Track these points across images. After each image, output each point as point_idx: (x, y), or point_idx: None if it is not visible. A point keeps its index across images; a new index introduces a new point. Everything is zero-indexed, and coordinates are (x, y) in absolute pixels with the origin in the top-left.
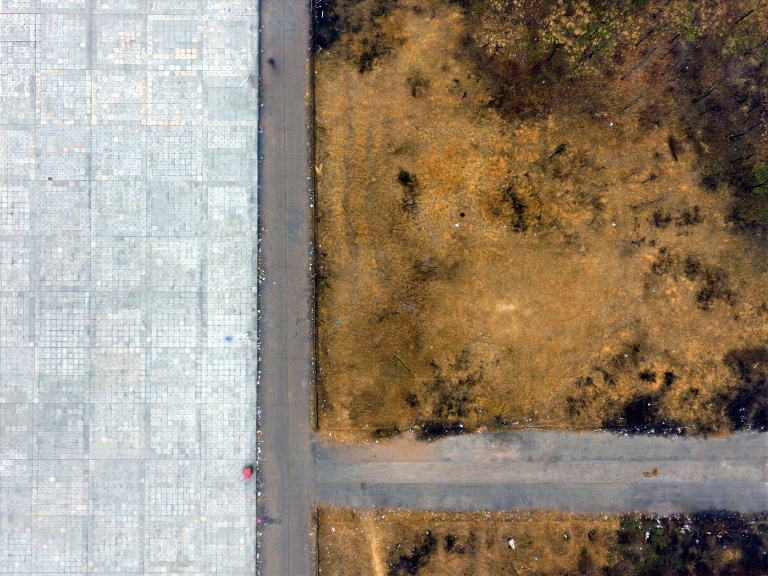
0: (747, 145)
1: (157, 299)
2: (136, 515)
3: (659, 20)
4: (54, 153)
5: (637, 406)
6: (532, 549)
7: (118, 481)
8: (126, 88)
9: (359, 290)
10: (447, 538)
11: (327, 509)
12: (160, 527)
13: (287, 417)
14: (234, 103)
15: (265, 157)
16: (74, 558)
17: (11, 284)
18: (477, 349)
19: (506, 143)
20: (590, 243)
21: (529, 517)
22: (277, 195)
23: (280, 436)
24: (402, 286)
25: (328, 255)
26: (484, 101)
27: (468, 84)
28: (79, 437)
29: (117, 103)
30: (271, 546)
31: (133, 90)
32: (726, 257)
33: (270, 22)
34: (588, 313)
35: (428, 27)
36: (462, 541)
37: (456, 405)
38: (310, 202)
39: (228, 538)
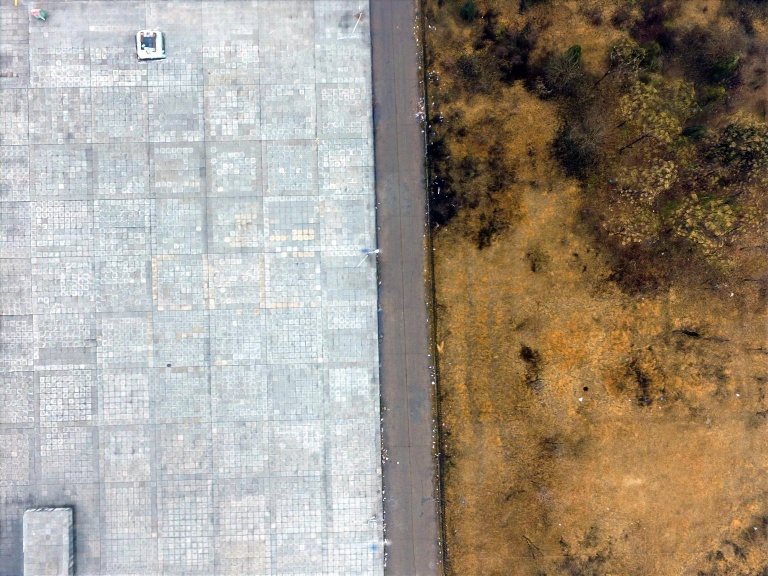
0: None
1: (281, 484)
2: None
3: None
4: (172, 339)
5: None
6: None
7: None
8: (244, 271)
9: (485, 469)
10: None
11: None
12: None
13: None
14: (353, 283)
15: (385, 335)
16: None
17: (132, 474)
18: (605, 525)
19: (628, 317)
20: (715, 415)
21: None
22: (398, 373)
23: None
24: (528, 464)
25: (452, 434)
26: (604, 275)
27: (588, 258)
28: None
29: (235, 286)
30: None
31: (251, 273)
32: None
33: (386, 199)
34: (716, 486)
35: (546, 201)
36: None
37: None
38: (431, 379)
39: None
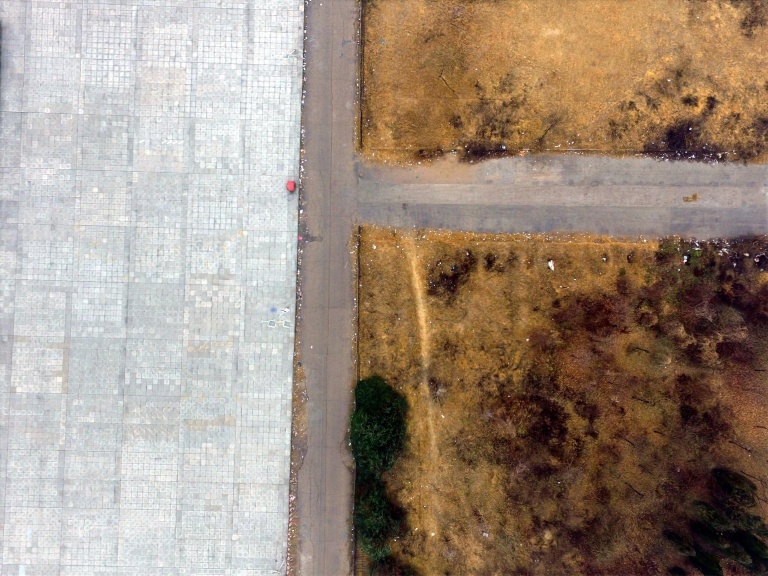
0: None
1: (204, 15)
2: (178, 227)
3: None
4: None
5: (679, 130)
6: (571, 269)
7: (161, 193)
8: None
9: (405, 11)
10: (487, 258)
11: (368, 228)
12: (202, 240)
13: (331, 137)
14: None
15: None
16: (115, 268)
17: None
18: (521, 73)
19: None
20: None
21: (569, 239)
22: None
23: (323, 155)
24: (448, 8)
25: None
26: None
27: None
28: (123, 149)
29: None
30: (312, 263)
31: None
32: None
33: None
34: (632, 39)
35: None
36: (502, 260)
37: (499, 127)
38: None
39: (269, 252)
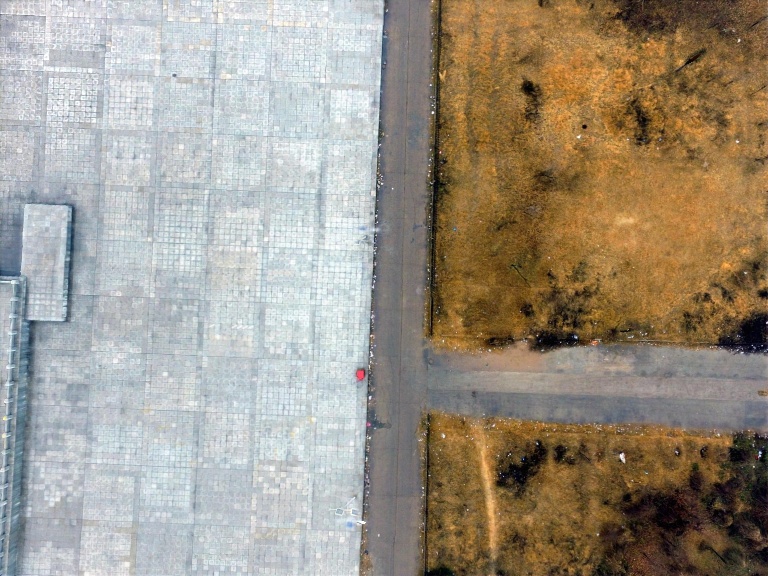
0: None
1: (276, 199)
2: (247, 413)
3: None
4: (179, 50)
5: (755, 324)
6: (643, 463)
7: (230, 378)
8: None
9: (478, 198)
10: (557, 449)
11: (437, 415)
12: (271, 426)
13: (400, 322)
14: (360, 6)
15: (388, 62)
16: (184, 453)
17: (132, 178)
18: (594, 261)
19: (632, 56)
20: (713, 159)
21: (641, 431)
22: (399, 101)
23: (393, 341)
24: (522, 195)
25: (448, 162)
26: (611, 13)
27: None
28: (193, 333)
29: (244, 2)
30: (380, 450)
31: None
32: None
33: None
34: (708, 229)
35: None
36: (573, 452)
37: (571, 316)
38: (431, 109)
39: (338, 440)
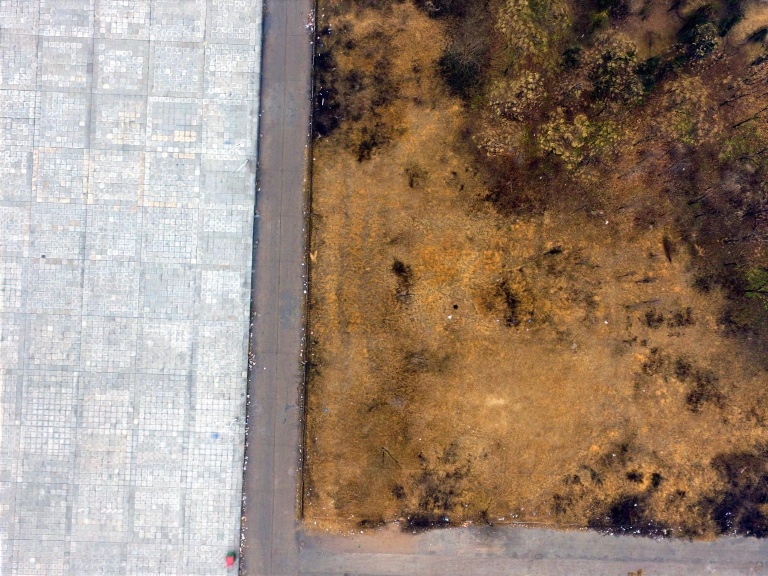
0: (740, 256)
1: (146, 381)
2: None
3: (656, 132)
4: (49, 230)
5: (623, 506)
6: None
7: (99, 564)
8: (124, 168)
9: (349, 379)
10: None
11: None
12: None
13: (272, 504)
14: (231, 187)
15: (260, 241)
16: None
17: None
18: (465, 442)
19: (501, 237)
20: (582, 341)
21: None
22: (271, 280)
23: (264, 523)
24: (393, 377)
25: (320, 343)
26: (481, 195)
27: (466, 177)
28: (61, 518)
29: (114, 183)
30: None
31: (131, 170)
32: (717, 360)
33: (271, 107)
34: (578, 411)
35: (428, 119)
36: None
37: (442, 498)
38: (304, 288)
39: None
